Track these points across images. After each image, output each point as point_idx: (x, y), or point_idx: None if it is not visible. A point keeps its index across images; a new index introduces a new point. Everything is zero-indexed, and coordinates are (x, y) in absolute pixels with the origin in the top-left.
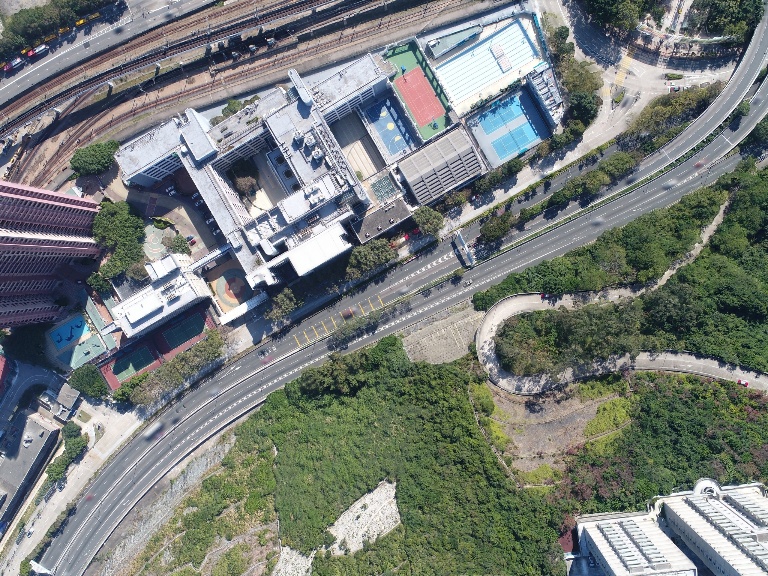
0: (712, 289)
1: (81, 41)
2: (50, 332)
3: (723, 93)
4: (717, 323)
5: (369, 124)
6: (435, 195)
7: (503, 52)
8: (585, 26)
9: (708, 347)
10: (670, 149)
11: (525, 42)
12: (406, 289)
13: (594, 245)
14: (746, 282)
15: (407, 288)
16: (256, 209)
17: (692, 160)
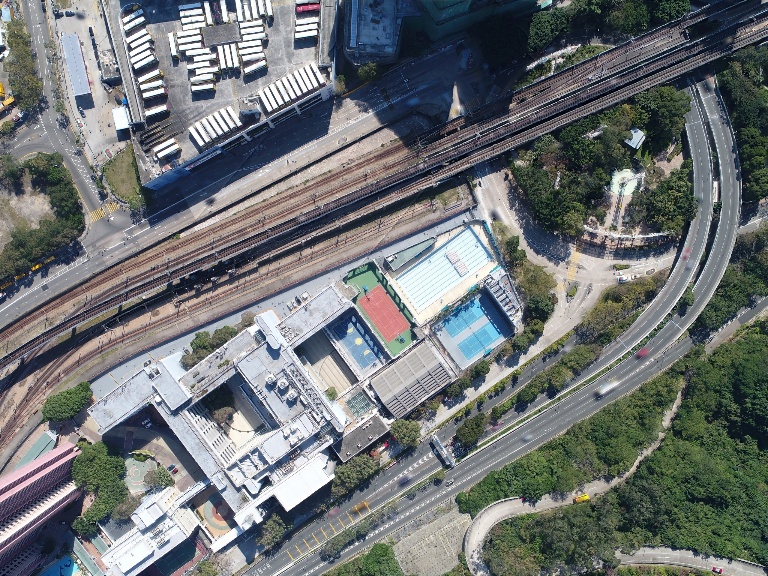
0: (679, 479)
1: (39, 284)
2: (39, 575)
3: (668, 282)
4: (688, 515)
5: (337, 341)
6: (409, 407)
7: (459, 258)
8: (533, 227)
9: (682, 541)
10: (625, 338)
11: (478, 246)
12: (391, 493)
13: (565, 440)
14: (710, 471)
15: (392, 492)
16: (235, 431)
17: (647, 347)
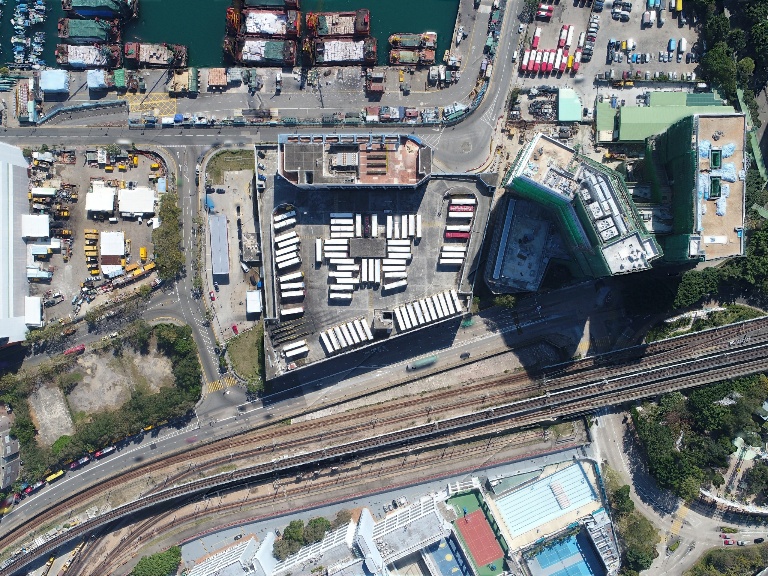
0: None
1: (148, 442)
2: None
3: None
4: None
5: (428, 554)
6: None
7: (562, 490)
8: (644, 474)
9: None
10: None
11: (584, 482)
12: None
13: None
14: None
15: None
16: None
17: None
